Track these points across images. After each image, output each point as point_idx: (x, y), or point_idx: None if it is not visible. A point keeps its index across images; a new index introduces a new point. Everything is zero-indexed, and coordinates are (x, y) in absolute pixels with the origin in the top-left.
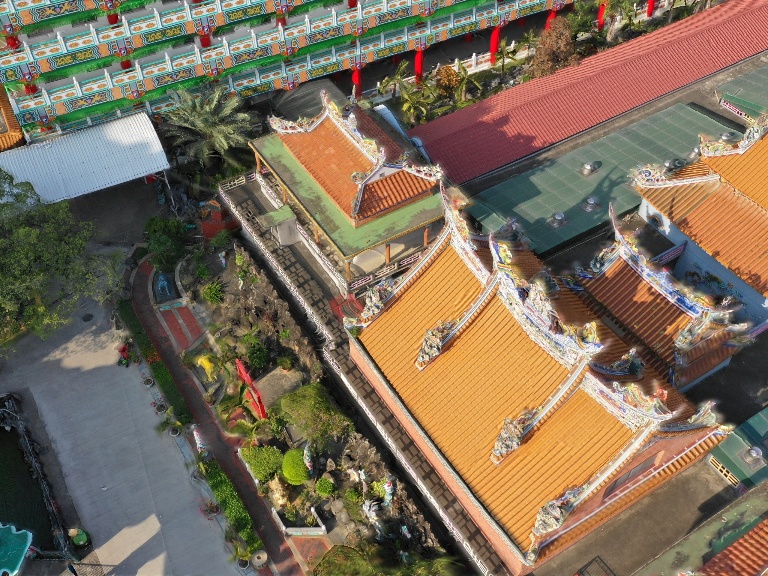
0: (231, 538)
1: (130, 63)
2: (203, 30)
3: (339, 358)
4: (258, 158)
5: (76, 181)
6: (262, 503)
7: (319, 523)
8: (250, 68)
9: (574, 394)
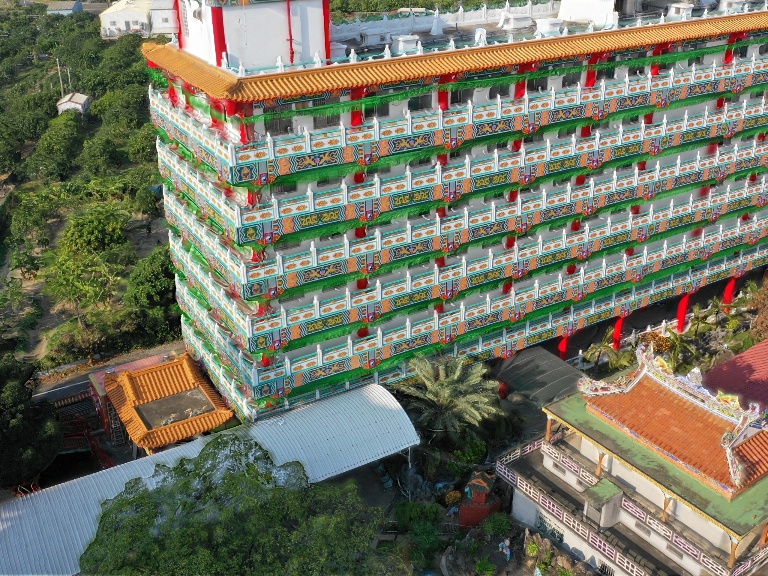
0: None
1: (367, 330)
2: (446, 294)
3: None
4: None
5: (323, 461)
6: None
7: None
8: (475, 335)
9: None
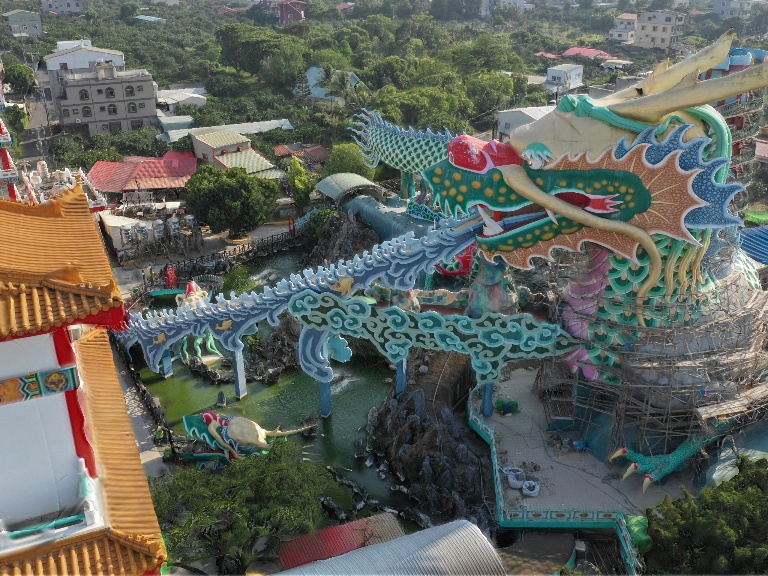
0: None
1: None
2: None
3: None
4: None
5: None
6: None
7: None
8: None
9: None
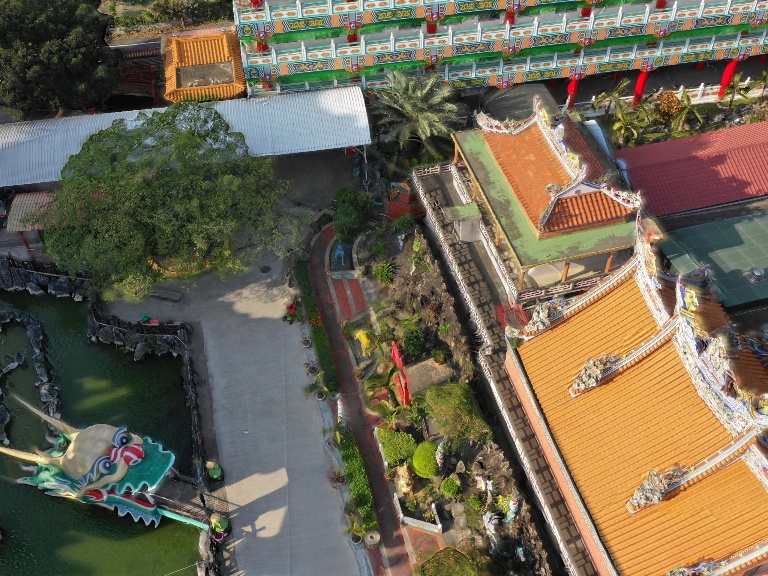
0: (350, 511)
1: (356, 37)
2: (432, 16)
3: (493, 364)
4: (457, 151)
5: (283, 140)
6: (386, 486)
7: (437, 520)
8: (469, 60)
9: (733, 463)
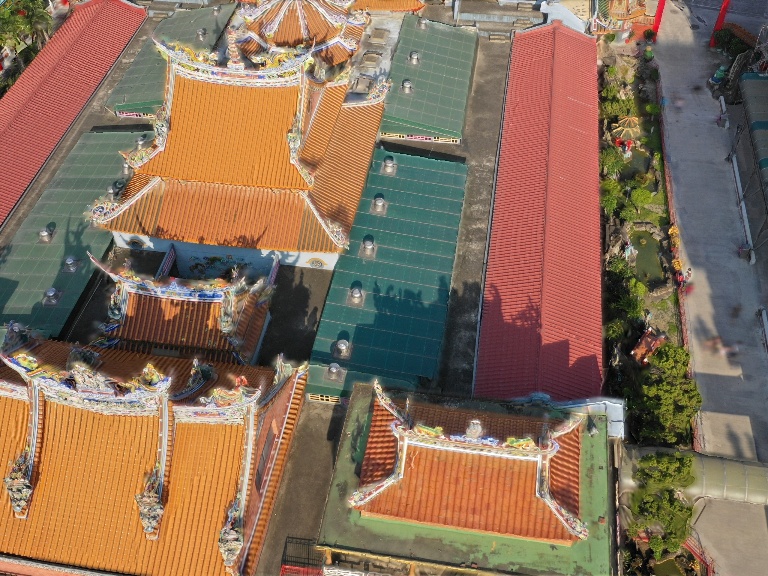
0: None
1: None
2: None
3: None
4: None
5: None
6: None
7: None
8: None
9: (176, 432)
